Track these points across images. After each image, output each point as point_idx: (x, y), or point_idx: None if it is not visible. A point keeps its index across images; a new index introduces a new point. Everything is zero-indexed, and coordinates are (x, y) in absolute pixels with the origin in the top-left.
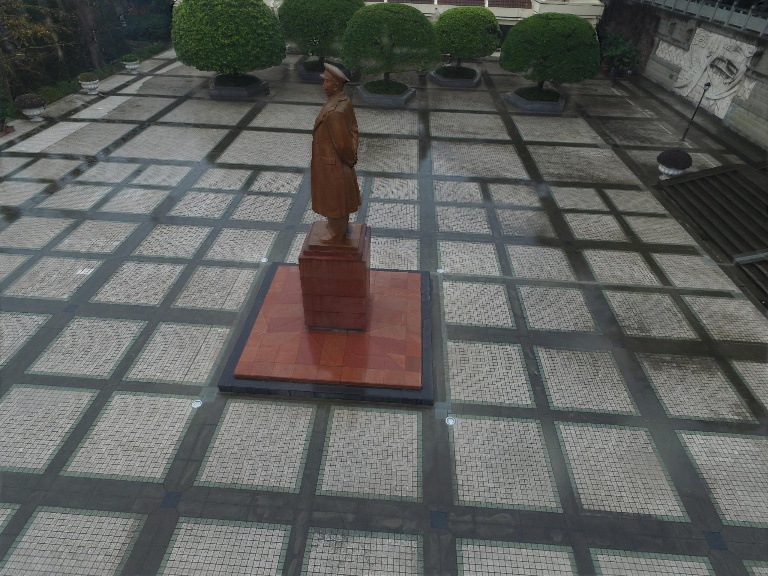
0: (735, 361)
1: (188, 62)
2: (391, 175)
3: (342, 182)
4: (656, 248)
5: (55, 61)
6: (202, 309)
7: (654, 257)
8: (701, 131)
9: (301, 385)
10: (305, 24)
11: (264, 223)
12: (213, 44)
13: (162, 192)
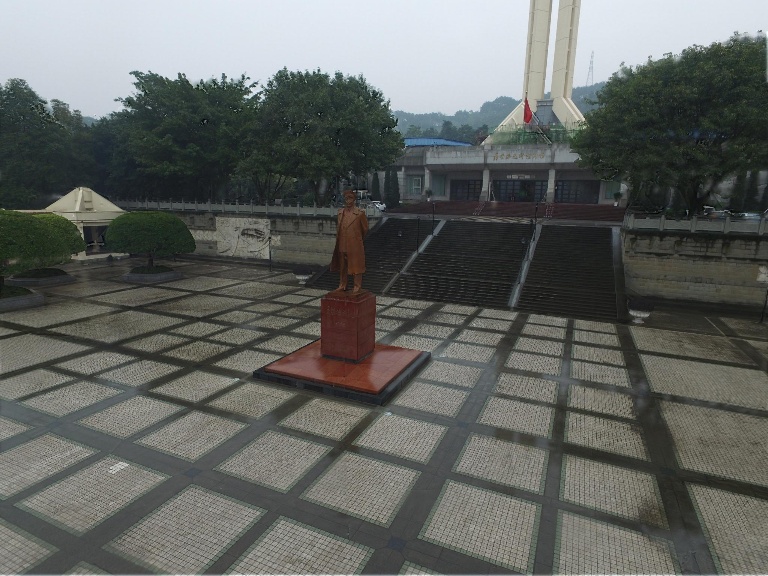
0: (439, 310)
1: None
2: None
3: None
4: None
5: None
6: (278, 406)
7: None
8: (268, 267)
9: (399, 377)
10: None
11: (172, 374)
12: None
13: None
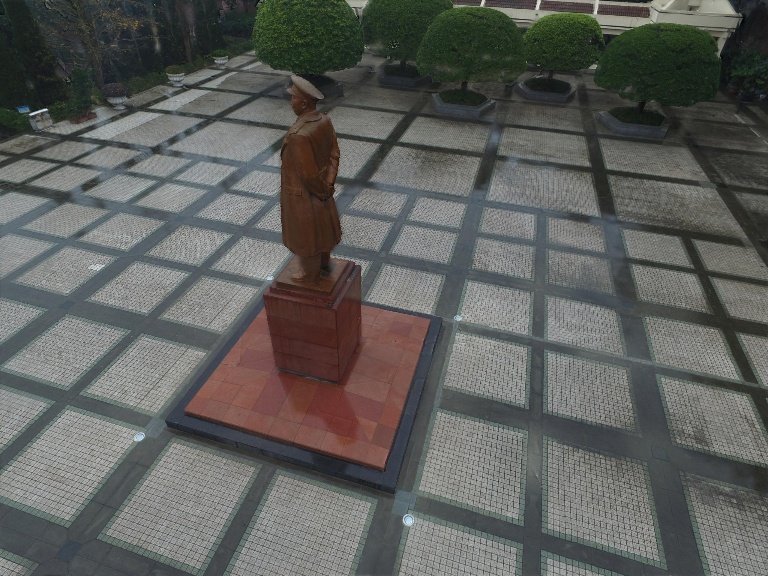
0: None
1: (264, 60)
2: (438, 196)
3: (310, 217)
4: (746, 327)
5: (151, 53)
6: (187, 325)
7: (740, 339)
8: None
9: (250, 437)
10: (386, 26)
11: None
12: (288, 43)
13: (199, 191)
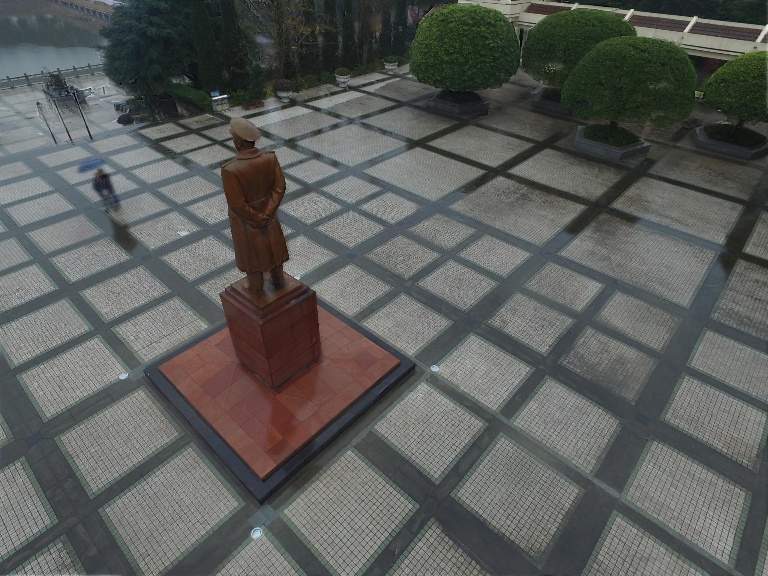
0: None
1: (413, 72)
2: (507, 238)
3: (243, 239)
4: None
5: (332, 54)
6: (210, 299)
7: None
8: None
9: (187, 408)
10: (546, 49)
11: (335, 243)
12: (435, 59)
13: (295, 186)
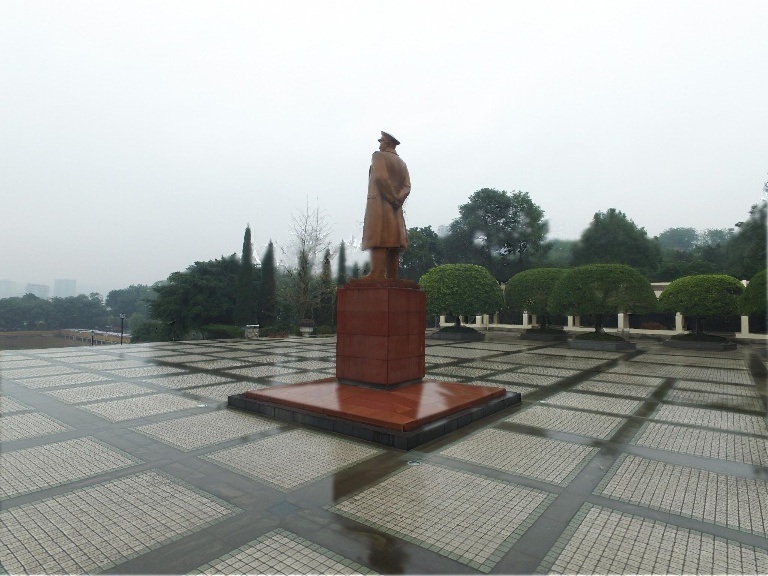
0: None
1: None
2: (552, 367)
3: (379, 213)
4: None
5: None
6: (282, 382)
7: None
8: None
9: (289, 407)
10: (523, 289)
11: None
12: (438, 294)
13: None
